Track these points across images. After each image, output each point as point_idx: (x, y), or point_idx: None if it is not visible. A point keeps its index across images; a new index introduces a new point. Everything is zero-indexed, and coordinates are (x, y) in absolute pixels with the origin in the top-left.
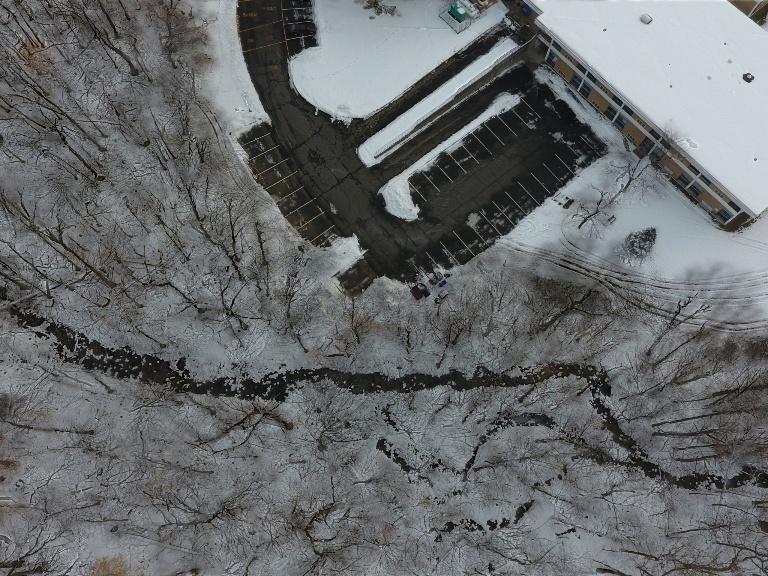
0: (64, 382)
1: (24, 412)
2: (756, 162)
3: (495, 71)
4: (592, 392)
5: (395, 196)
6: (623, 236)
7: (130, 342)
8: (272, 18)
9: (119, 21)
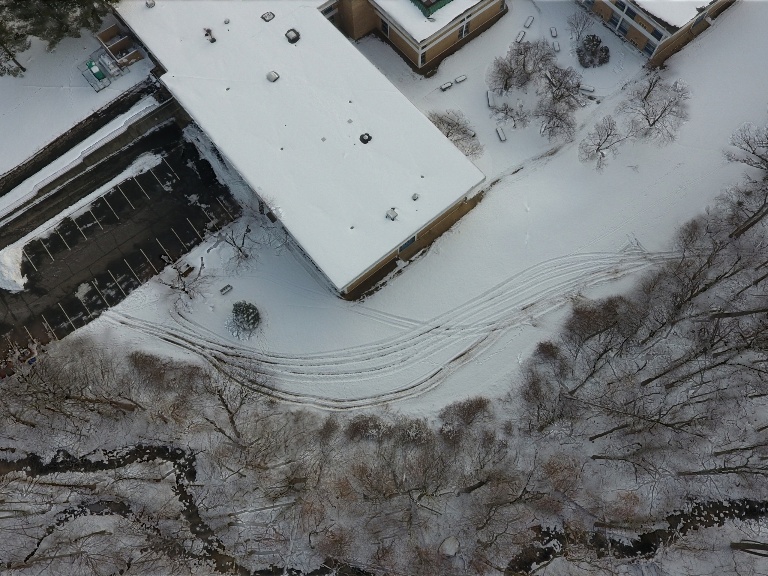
0: None
1: None
2: (352, 231)
3: (135, 130)
4: (176, 477)
5: None
6: None
7: None
8: None
9: None
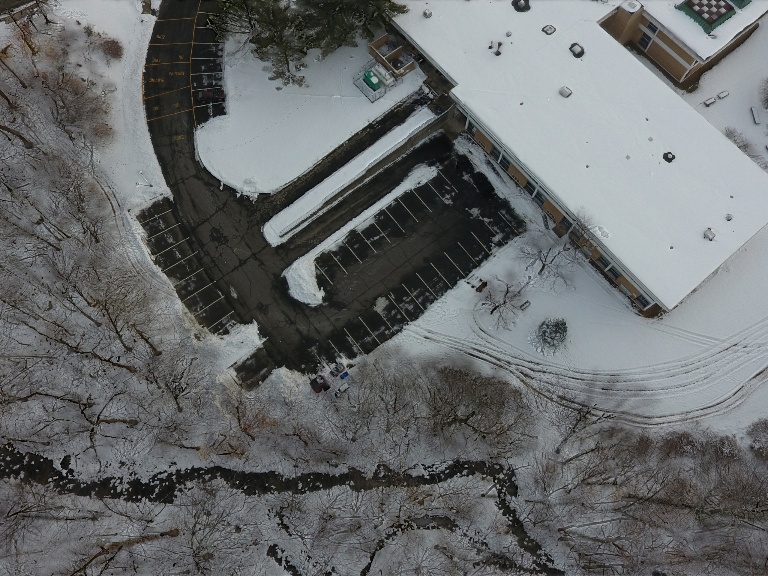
0: None
1: None
2: (672, 251)
3: (411, 142)
4: (498, 492)
5: (298, 280)
6: (537, 323)
7: None
8: (180, 84)
9: (15, 89)
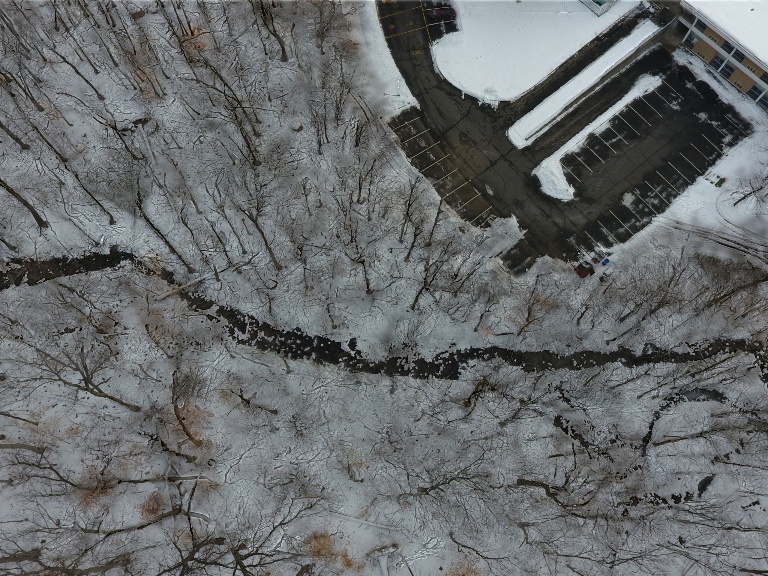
0: (242, 363)
1: (207, 393)
2: None
3: (636, 53)
4: (760, 367)
5: (551, 177)
6: None
7: (301, 323)
8: (411, 4)
9: None
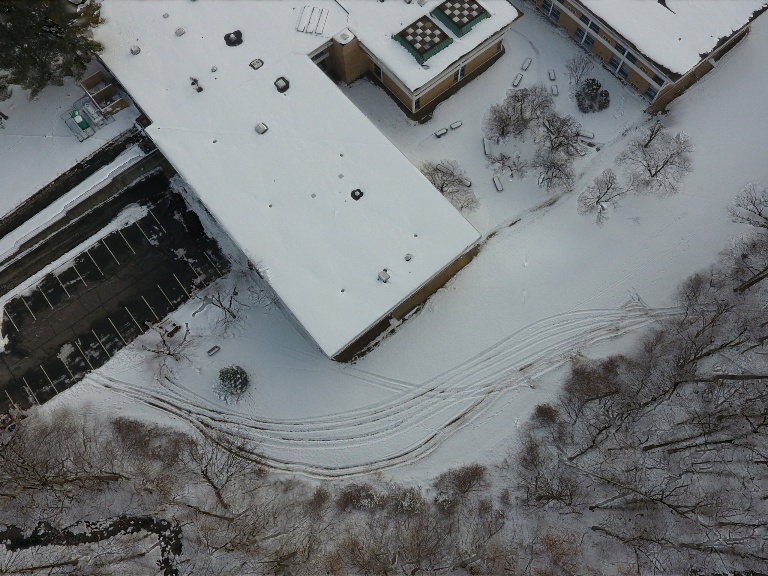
0: None
1: None
2: (343, 294)
3: (120, 182)
4: (162, 550)
5: None
6: None
7: None
8: None
9: None
